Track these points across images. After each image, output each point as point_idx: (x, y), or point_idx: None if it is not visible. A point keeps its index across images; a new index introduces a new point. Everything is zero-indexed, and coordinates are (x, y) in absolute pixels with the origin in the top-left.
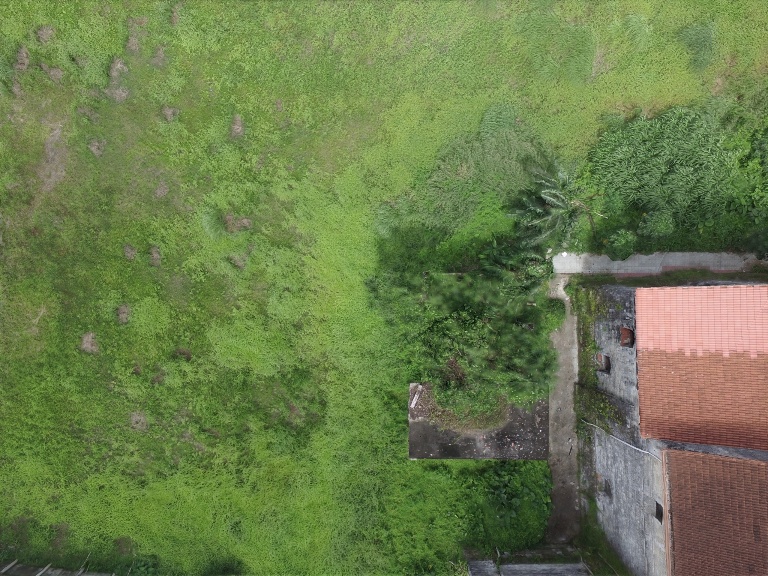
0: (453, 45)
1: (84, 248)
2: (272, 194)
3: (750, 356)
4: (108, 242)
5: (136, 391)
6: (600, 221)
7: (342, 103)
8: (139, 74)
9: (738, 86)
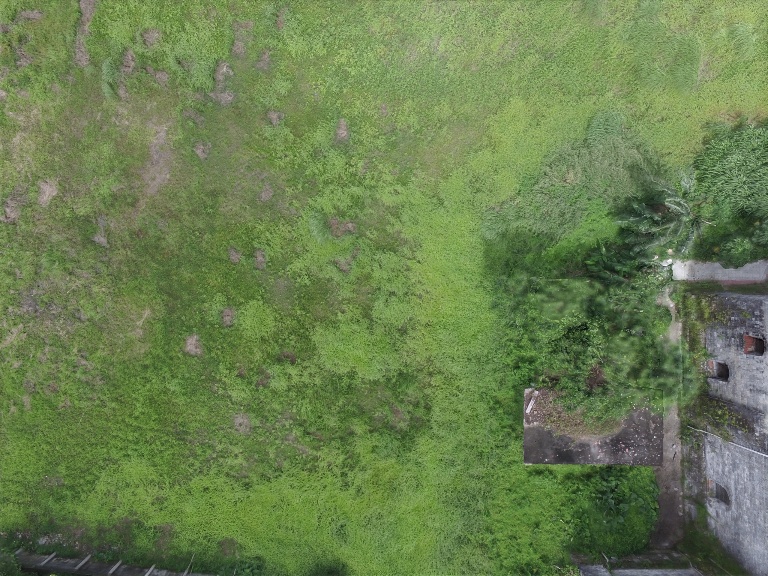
0: (559, 52)
1: (189, 251)
2: (377, 199)
3: None
4: (213, 245)
5: (241, 394)
6: (707, 229)
7: (447, 109)
8: (244, 78)
9: None
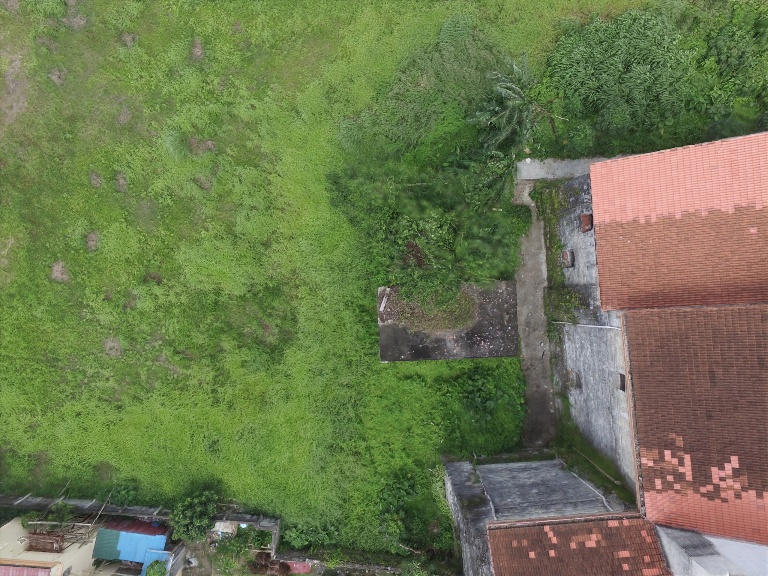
0: None
1: (50, 178)
2: (235, 115)
3: (701, 214)
4: (73, 170)
5: (108, 317)
6: (561, 124)
7: (301, 21)
8: (97, 1)
9: None
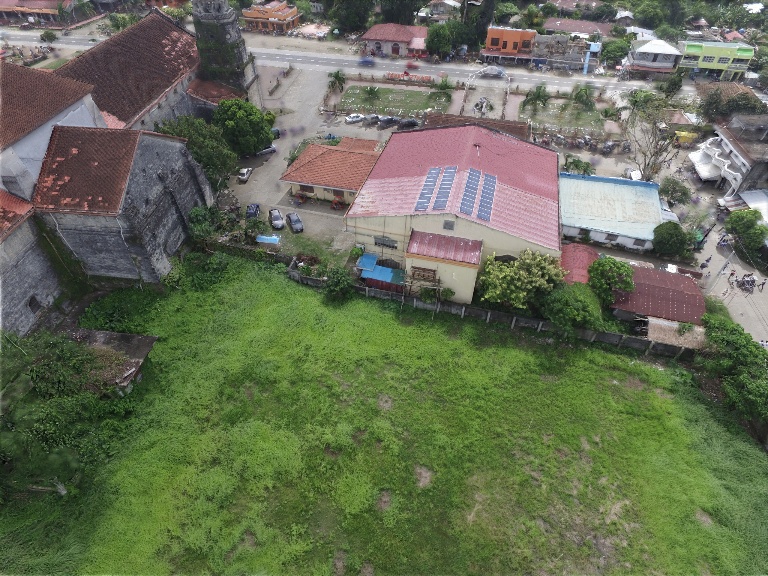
0: None
1: None
2: None
3: None
4: None
5: (381, 425)
6: None
7: None
8: None
9: None
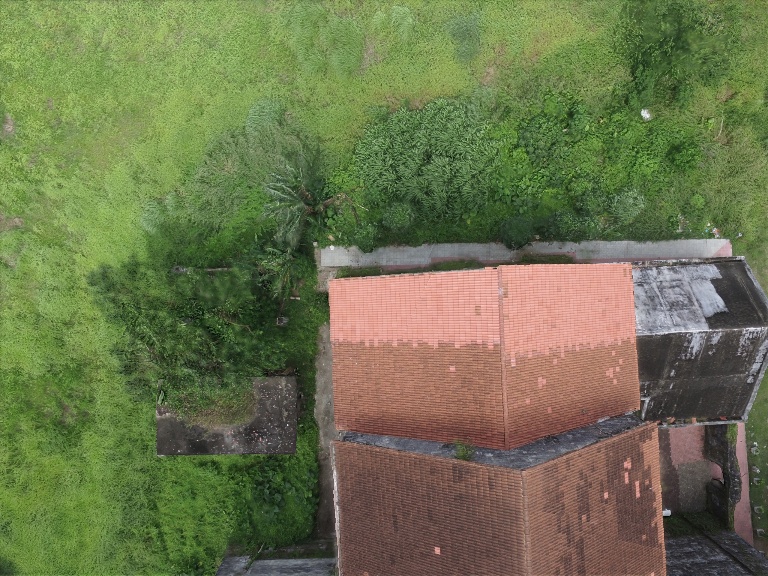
0: (221, 39)
1: None
2: (44, 193)
3: (412, 345)
4: None
5: None
6: (363, 213)
7: (112, 100)
8: None
9: (507, 75)
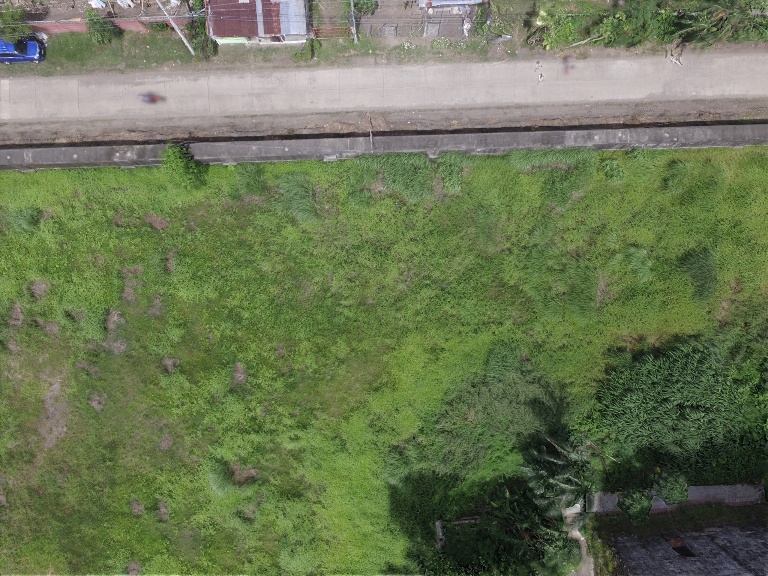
0: (454, 283)
1: (90, 506)
2: (278, 442)
3: None
4: (114, 498)
5: None
6: (612, 463)
7: (345, 347)
8: (137, 325)
9: (744, 312)
